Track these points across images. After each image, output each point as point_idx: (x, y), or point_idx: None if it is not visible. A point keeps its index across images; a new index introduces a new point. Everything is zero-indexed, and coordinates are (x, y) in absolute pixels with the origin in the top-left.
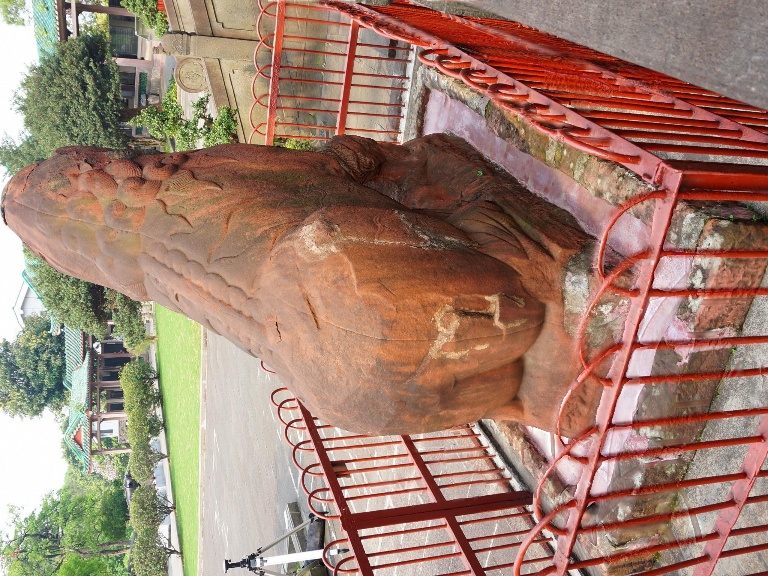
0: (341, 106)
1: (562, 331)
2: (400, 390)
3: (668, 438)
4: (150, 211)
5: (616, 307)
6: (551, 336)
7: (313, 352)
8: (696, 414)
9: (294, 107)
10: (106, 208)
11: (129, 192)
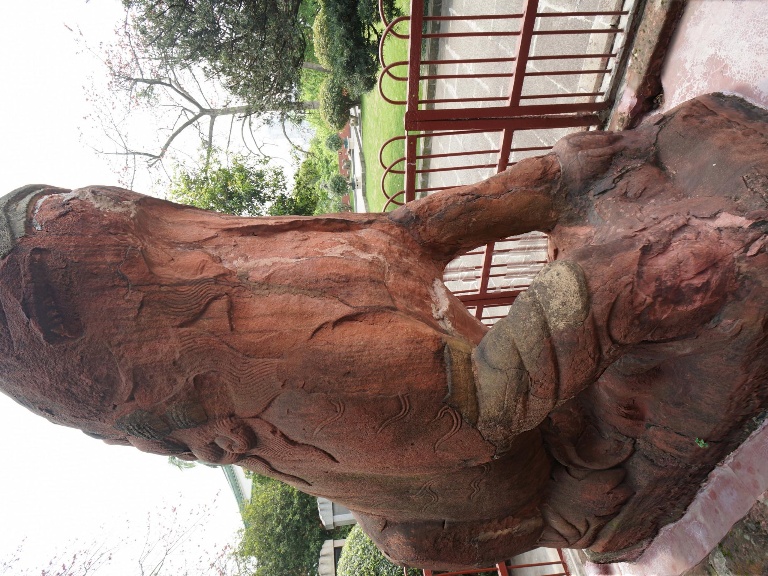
0: None
1: None
2: None
3: None
4: None
5: None
6: None
7: None
8: None
9: None
10: None
11: None
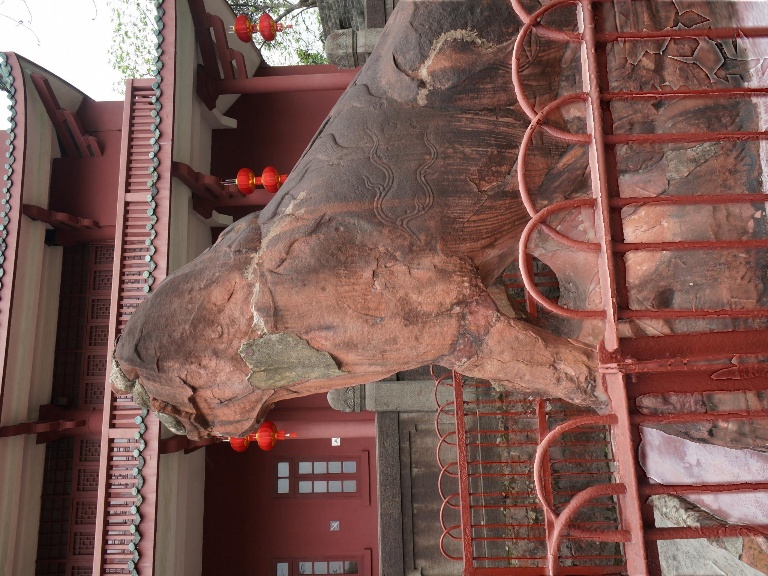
0: None
1: None
2: None
3: None
4: None
5: None
6: None
7: None
8: None
9: None
10: None
11: None
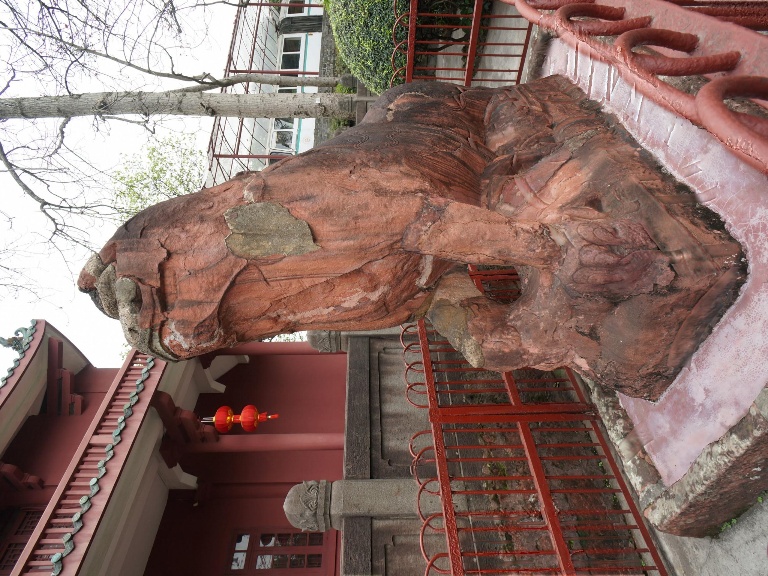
0: None
1: None
2: None
3: None
4: None
5: None
6: None
7: None
8: None
9: None
10: None
11: None
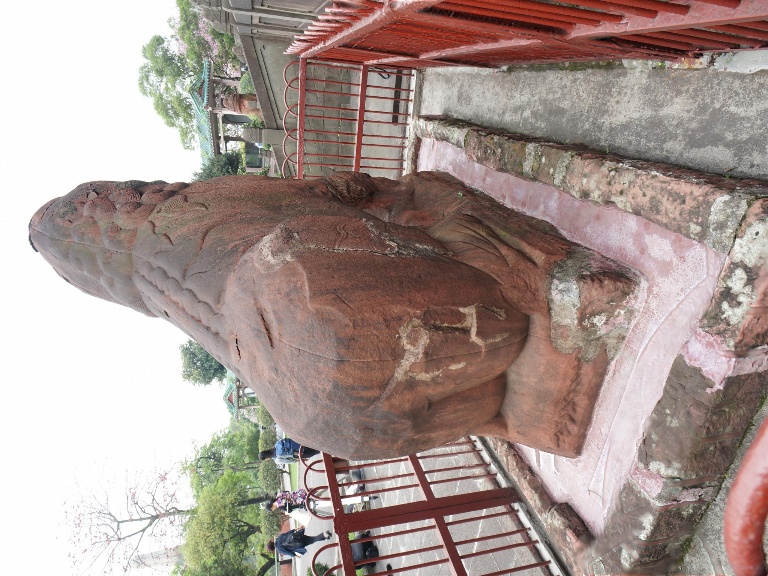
0: (355, 161)
1: (549, 345)
2: (364, 417)
3: (689, 478)
4: (141, 232)
5: (611, 318)
6: (536, 351)
7: (268, 373)
8: (724, 448)
9: (318, 163)
10: (103, 231)
11: (123, 215)
